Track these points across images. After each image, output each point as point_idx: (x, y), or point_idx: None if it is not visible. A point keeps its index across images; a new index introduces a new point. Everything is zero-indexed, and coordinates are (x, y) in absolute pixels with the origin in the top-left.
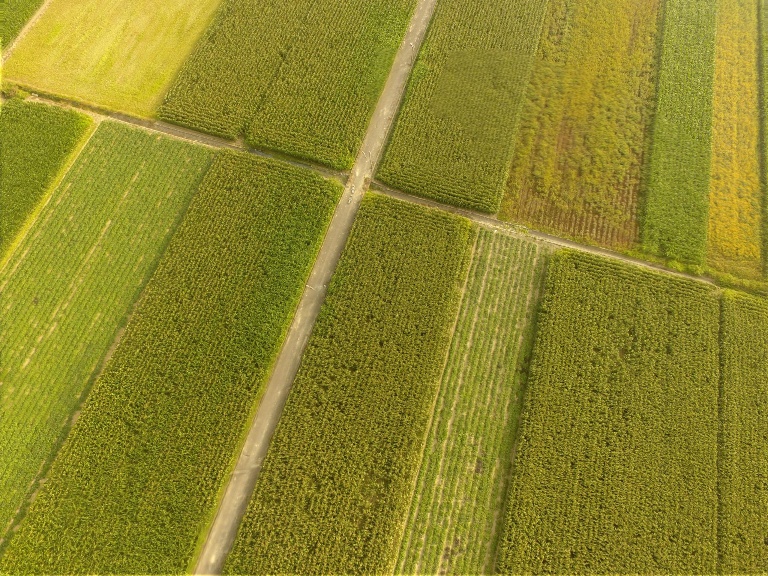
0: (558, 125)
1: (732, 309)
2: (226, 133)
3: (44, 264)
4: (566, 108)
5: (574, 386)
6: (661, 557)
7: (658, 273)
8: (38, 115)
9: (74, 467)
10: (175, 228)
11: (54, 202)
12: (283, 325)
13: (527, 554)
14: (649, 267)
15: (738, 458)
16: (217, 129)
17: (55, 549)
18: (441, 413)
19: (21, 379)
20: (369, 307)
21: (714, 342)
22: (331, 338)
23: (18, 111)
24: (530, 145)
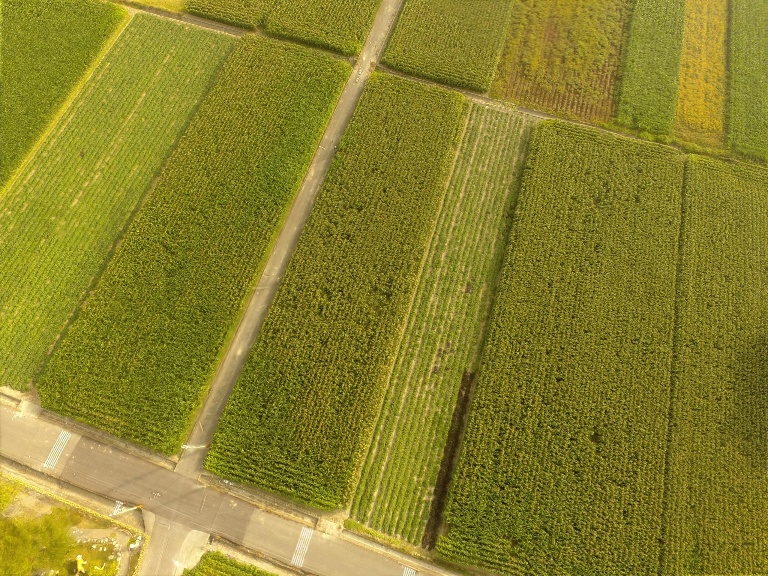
0: (545, 22)
1: (695, 169)
2: (247, 22)
3: (88, 126)
4: (553, 8)
5: (553, 225)
6: (624, 355)
7: (630, 140)
8: (80, 6)
9: (120, 278)
10: (203, 99)
11: (95, 77)
12: (299, 173)
13: (508, 350)
14: (623, 136)
15: (694, 282)
16: (239, 19)
17: (105, 338)
18: (436, 247)
19: (71, 214)
20: (374, 162)
21: (677, 194)
22: (341, 185)
23: (62, 2)
24: (519, 37)
